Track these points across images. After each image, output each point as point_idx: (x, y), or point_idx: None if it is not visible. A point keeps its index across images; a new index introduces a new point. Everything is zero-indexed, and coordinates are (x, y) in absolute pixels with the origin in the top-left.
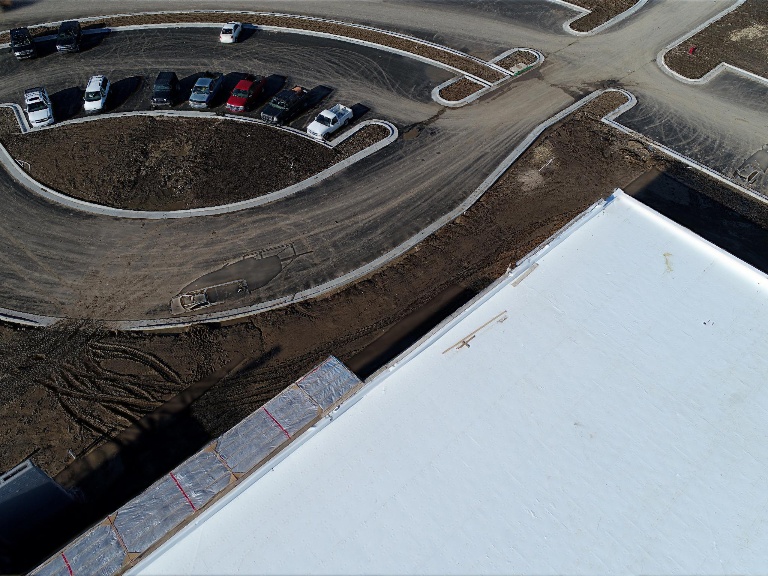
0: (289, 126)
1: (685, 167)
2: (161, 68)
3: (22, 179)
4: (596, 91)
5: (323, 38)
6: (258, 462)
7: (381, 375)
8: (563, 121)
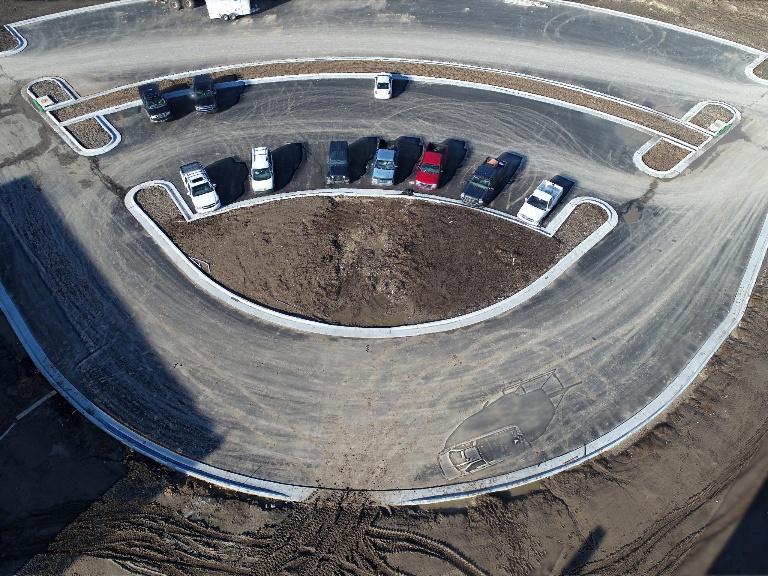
0: (491, 207)
1: None
2: (318, 132)
3: (205, 284)
4: None
5: (485, 91)
6: None
7: None
8: None
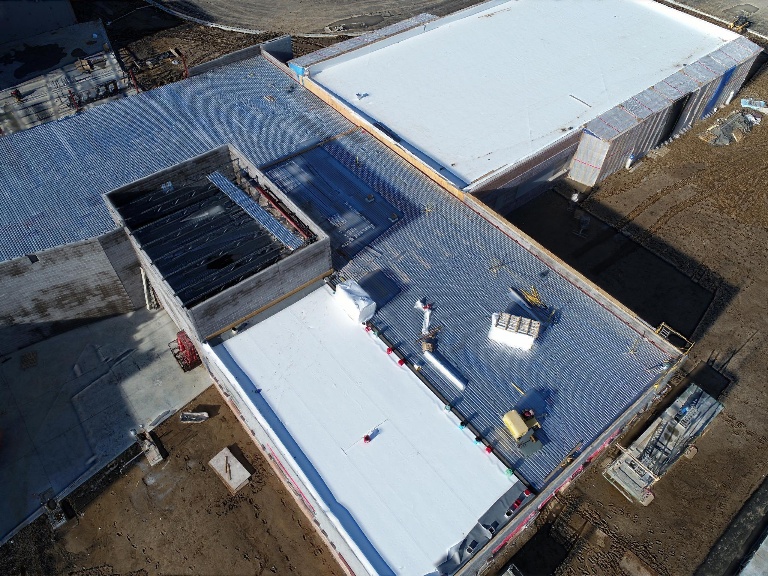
0: None
1: None
2: None
3: None
4: None
5: None
6: (394, 33)
7: (448, 16)
8: None
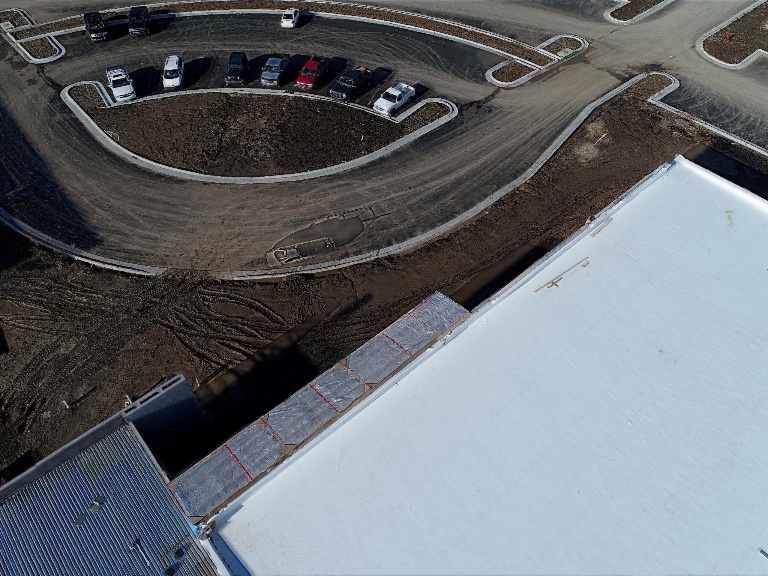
0: (355, 103)
1: (730, 143)
2: (228, 50)
3: (113, 148)
4: (640, 74)
5: (377, 24)
6: (387, 375)
7: (485, 307)
8: (612, 101)
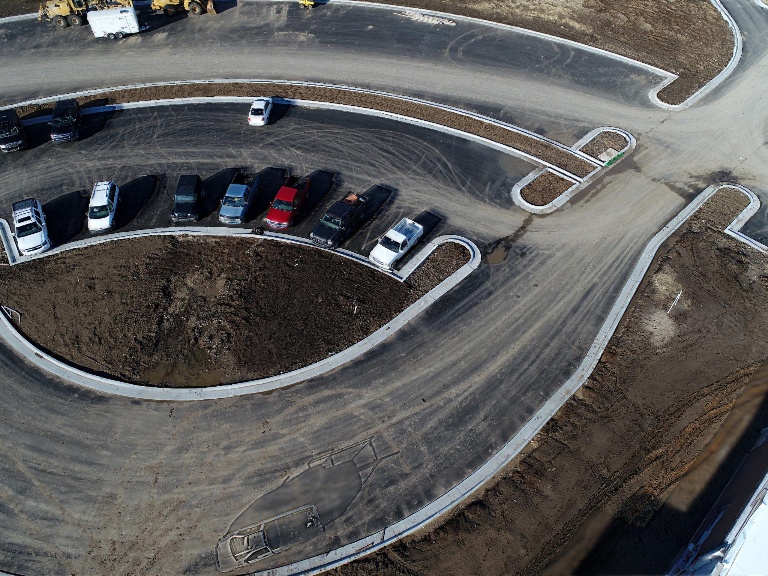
0: (345, 248)
1: None
2: (179, 163)
3: (10, 338)
4: (708, 188)
5: (370, 116)
6: None
7: None
8: (678, 233)
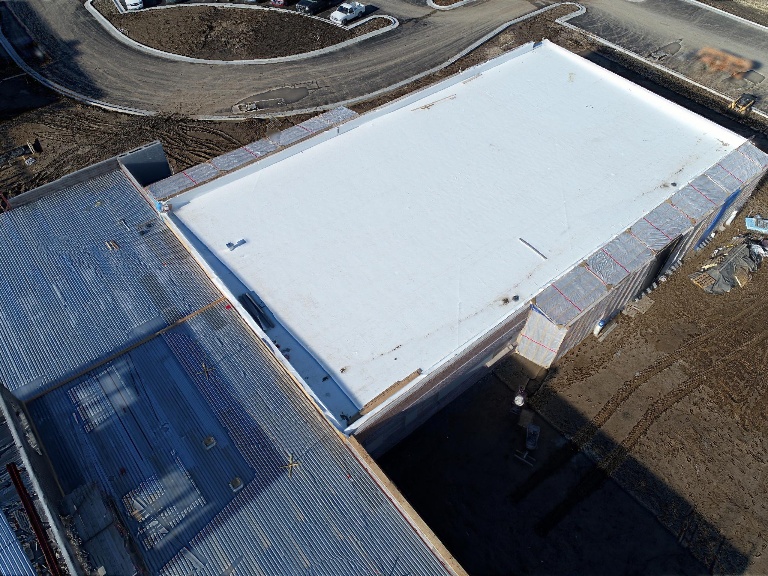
0: (317, 16)
1: (613, 50)
2: None
3: (123, 39)
4: (556, 4)
5: None
6: (294, 141)
7: (370, 113)
8: (526, 21)
